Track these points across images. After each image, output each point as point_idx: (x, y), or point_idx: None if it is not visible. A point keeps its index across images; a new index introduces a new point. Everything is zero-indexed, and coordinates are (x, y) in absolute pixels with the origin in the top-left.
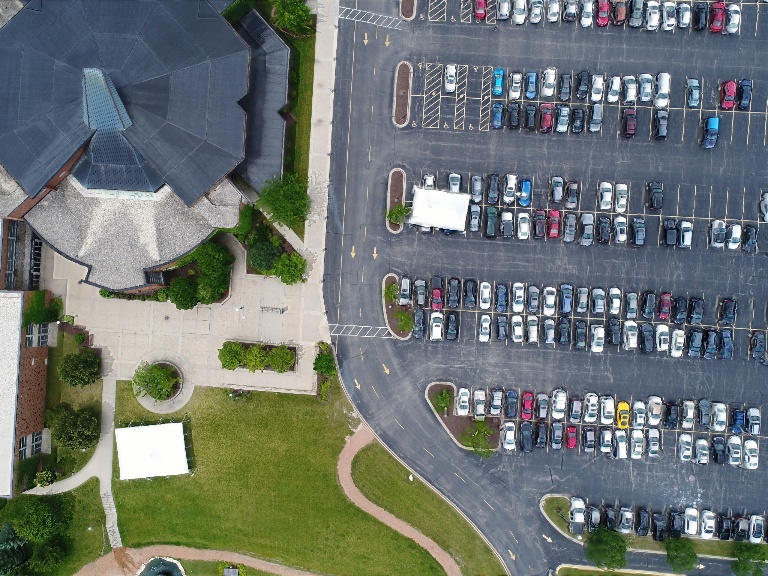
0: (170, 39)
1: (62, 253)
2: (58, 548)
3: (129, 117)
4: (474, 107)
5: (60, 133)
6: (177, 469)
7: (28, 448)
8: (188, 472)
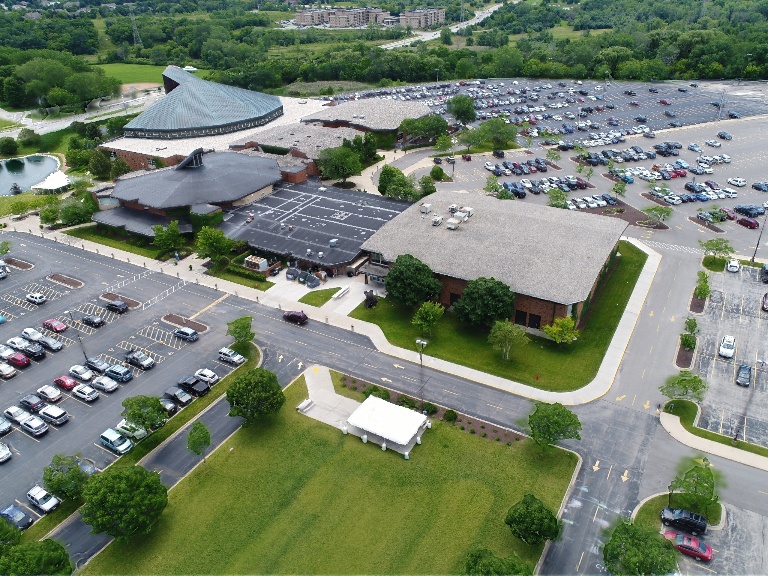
0: (199, 187)
1: (165, 166)
2: (71, 164)
3: (177, 168)
4: (3, 306)
5: (203, 159)
6: (39, 185)
7: (114, 159)
8: (33, 188)
